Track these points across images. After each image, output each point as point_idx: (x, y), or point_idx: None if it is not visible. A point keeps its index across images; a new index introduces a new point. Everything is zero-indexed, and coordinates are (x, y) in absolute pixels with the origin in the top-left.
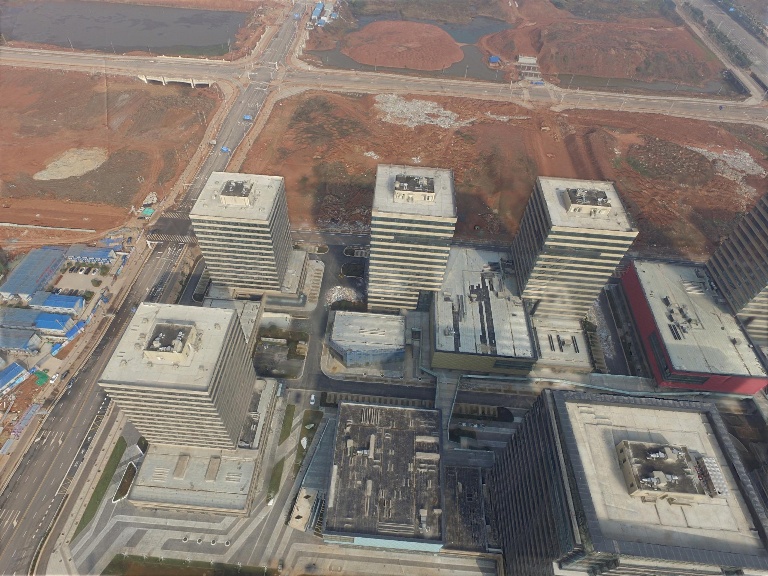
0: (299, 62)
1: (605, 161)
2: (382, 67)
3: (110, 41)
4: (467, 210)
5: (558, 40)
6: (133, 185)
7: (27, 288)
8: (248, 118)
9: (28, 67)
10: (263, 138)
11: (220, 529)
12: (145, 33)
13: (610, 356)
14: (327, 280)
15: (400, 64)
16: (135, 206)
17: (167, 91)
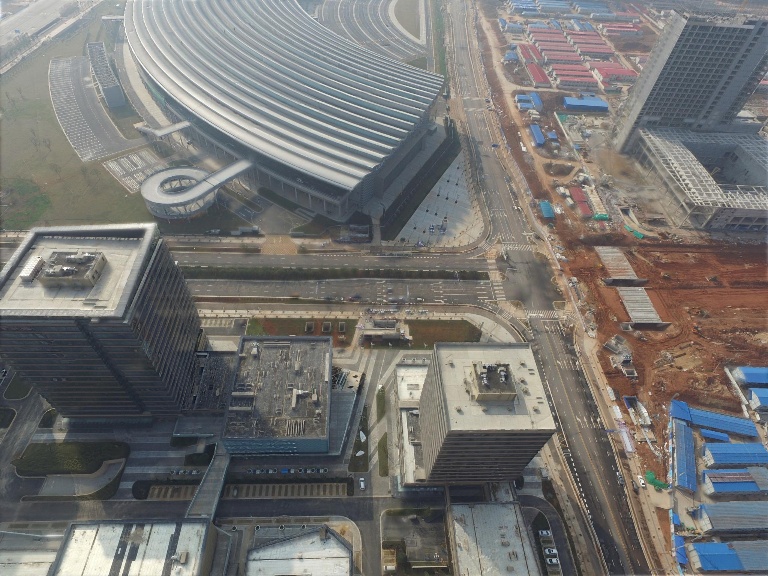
0: None
1: None
2: None
3: None
4: None
5: None
6: None
7: None
8: None
9: None
10: None
11: None
12: None
13: None
14: None
15: None
16: None
17: None
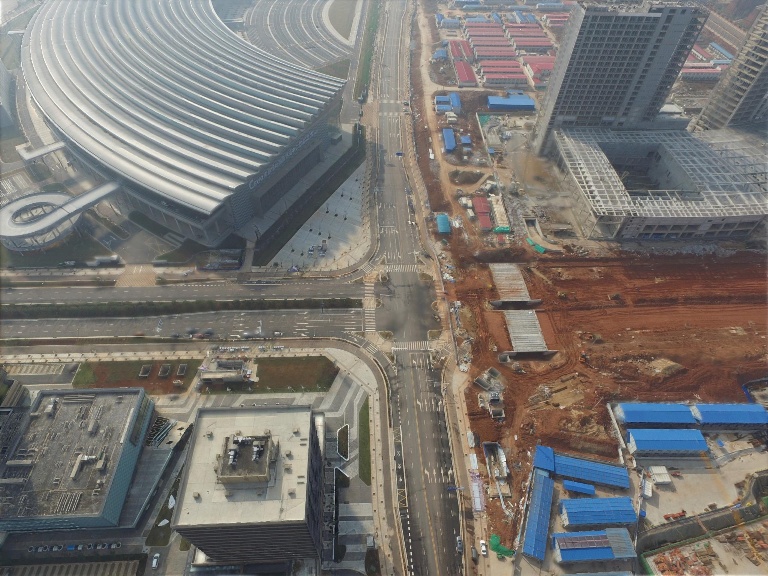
0: None
1: None
2: None
3: None
4: None
5: None
6: None
7: None
8: None
9: None
10: None
11: None
12: None
13: None
14: None
15: None
16: None
17: None
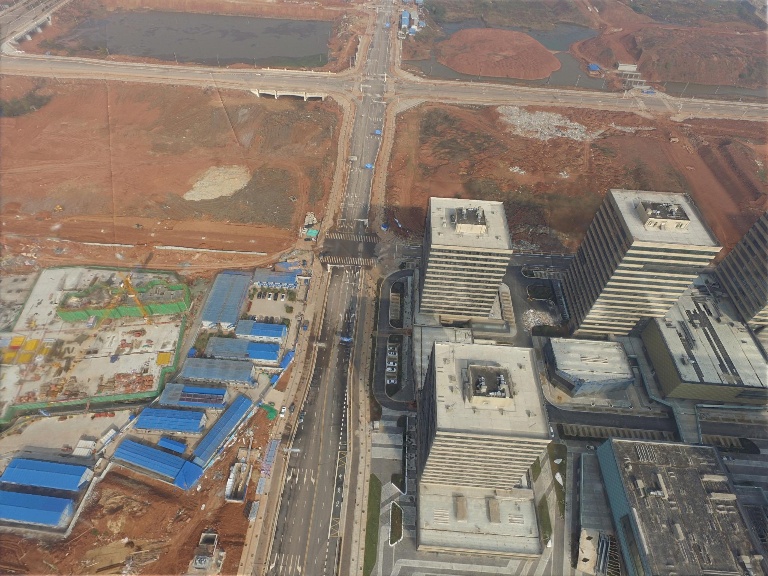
0: (404, 73)
1: (752, 174)
2: (483, 77)
3: (216, 54)
4: None
5: (657, 47)
6: (287, 205)
7: (228, 316)
8: (379, 133)
9: (138, 82)
10: (399, 153)
11: (509, 573)
12: (237, 44)
13: None
14: (517, 303)
15: (502, 73)
16: (297, 227)
17: (282, 105)
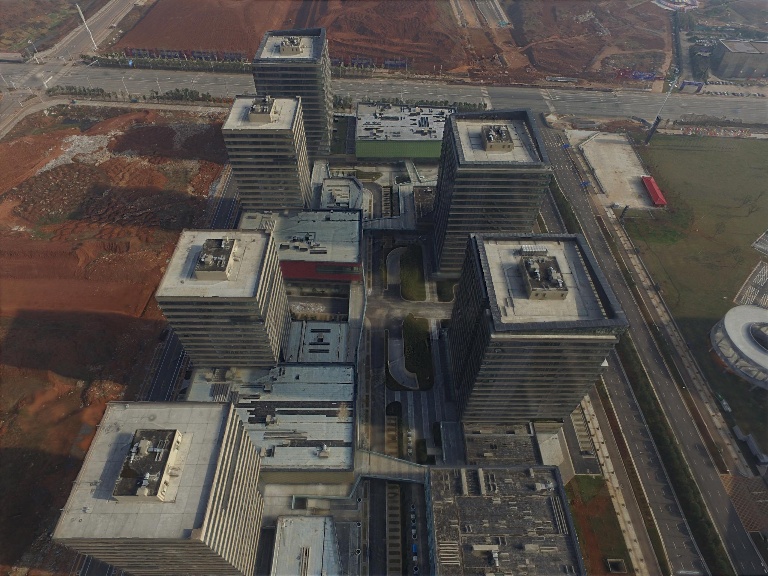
0: None
1: (35, 244)
2: None
3: None
4: (73, 421)
5: None
6: None
7: None
8: None
9: None
10: None
11: None
12: None
13: (323, 308)
14: None
15: None
16: None
17: None
